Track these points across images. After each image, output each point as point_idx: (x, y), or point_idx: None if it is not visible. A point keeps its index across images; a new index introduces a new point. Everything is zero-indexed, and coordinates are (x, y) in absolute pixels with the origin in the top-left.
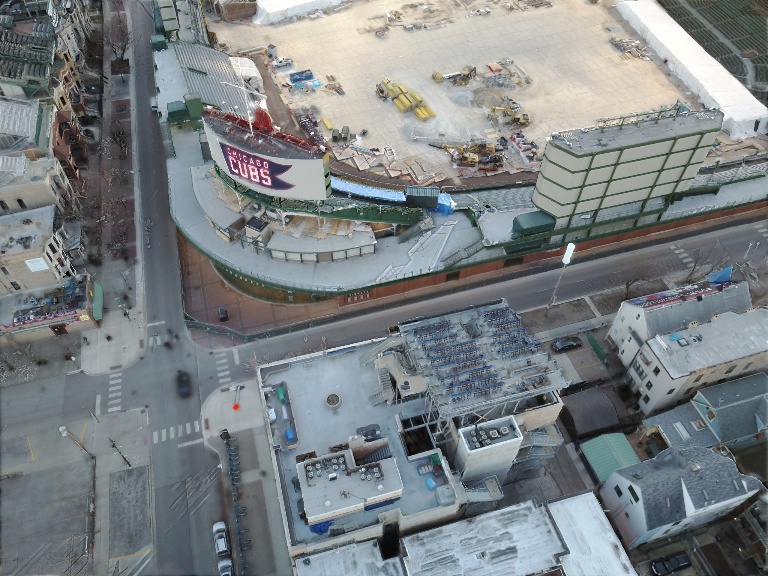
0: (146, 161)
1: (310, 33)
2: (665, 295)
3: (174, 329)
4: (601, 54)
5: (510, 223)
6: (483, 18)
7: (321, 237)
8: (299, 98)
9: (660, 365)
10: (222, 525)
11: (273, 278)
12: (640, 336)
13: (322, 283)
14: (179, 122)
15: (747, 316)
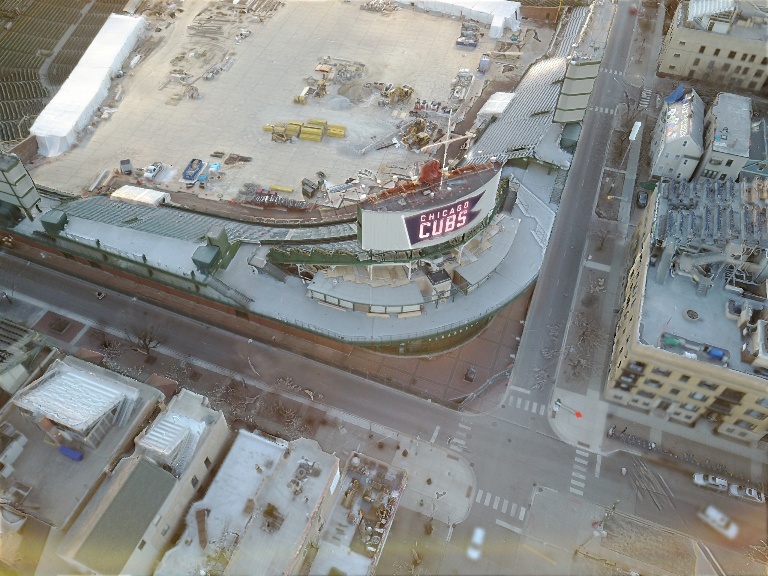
0: (179, 343)
1: (128, 132)
2: (674, 123)
3: (453, 422)
4: (369, 20)
5: (554, 147)
6: (252, 38)
7: (489, 246)
8: (221, 188)
9: (734, 156)
10: (700, 475)
11: (500, 303)
12: (691, 155)
13: (521, 278)
14: (216, 268)
15: (720, 104)
